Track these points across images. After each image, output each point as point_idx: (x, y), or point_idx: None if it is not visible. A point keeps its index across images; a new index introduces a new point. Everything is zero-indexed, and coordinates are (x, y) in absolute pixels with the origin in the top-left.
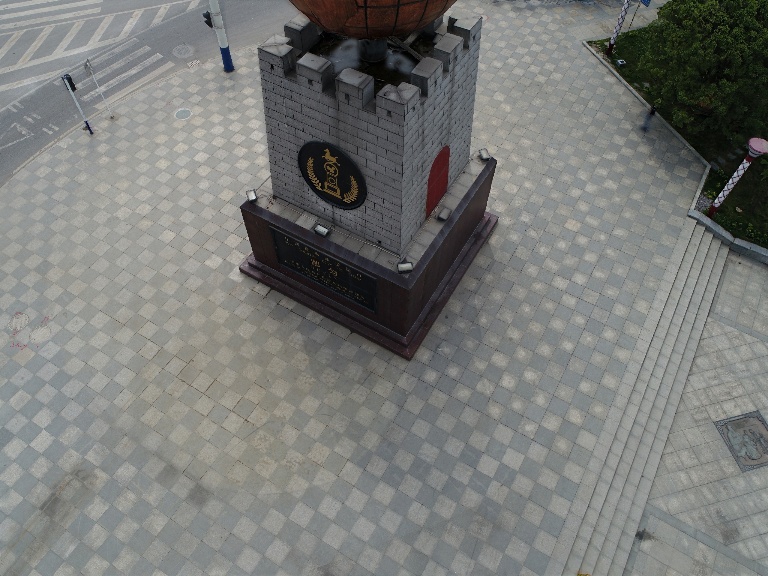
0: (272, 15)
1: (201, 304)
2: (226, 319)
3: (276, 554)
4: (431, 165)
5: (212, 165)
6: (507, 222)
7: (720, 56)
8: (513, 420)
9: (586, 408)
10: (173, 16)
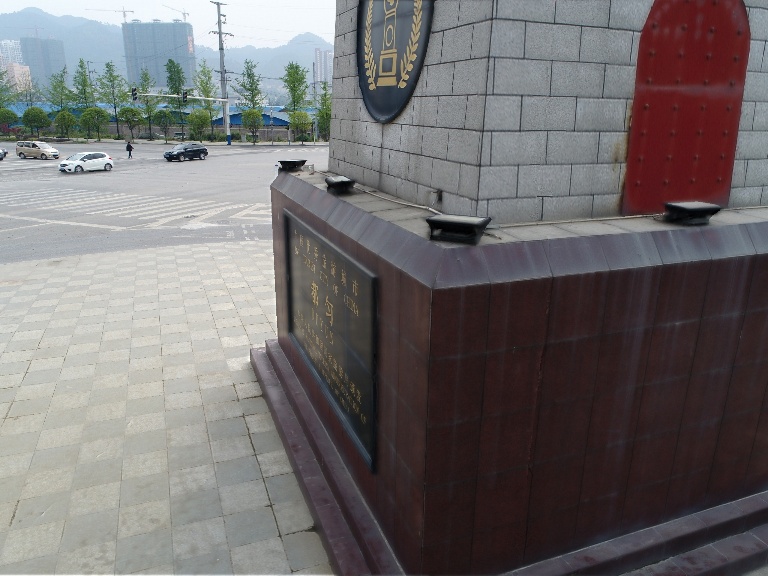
0: None
1: (147, 368)
2: (145, 397)
3: None
4: None
5: None
6: None
7: None
8: None
9: None
10: None
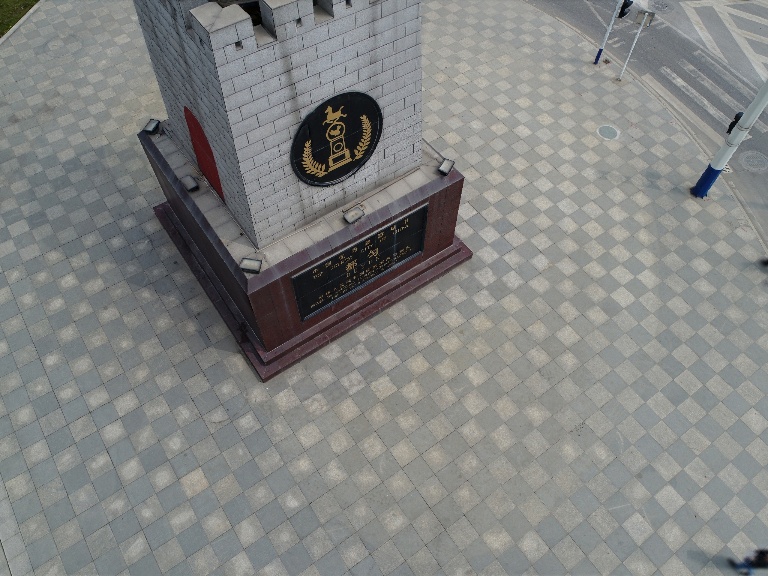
0: None
1: None
2: None
3: (85, 90)
4: None
5: (505, 136)
6: (255, 394)
7: None
8: (33, 266)
9: None
10: None
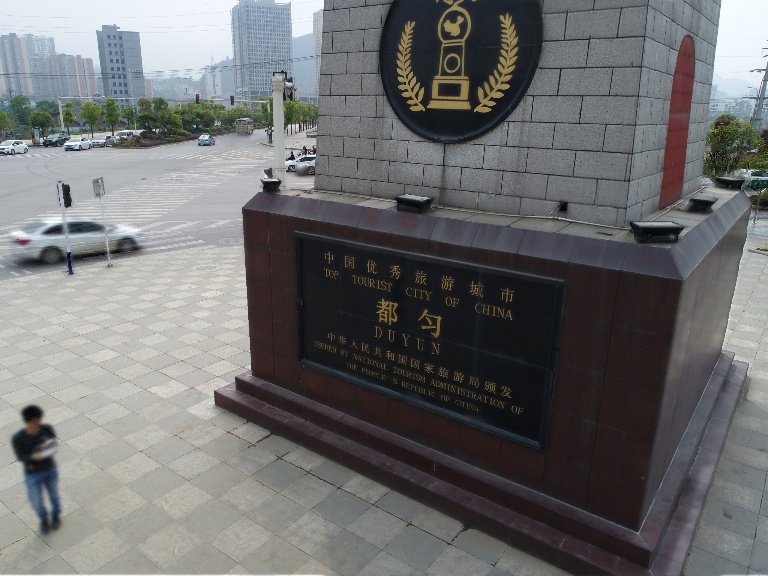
0: None
1: (101, 445)
2: (143, 474)
3: None
4: (679, 40)
5: (224, 300)
6: (767, 377)
7: None
8: None
9: None
10: (232, 225)
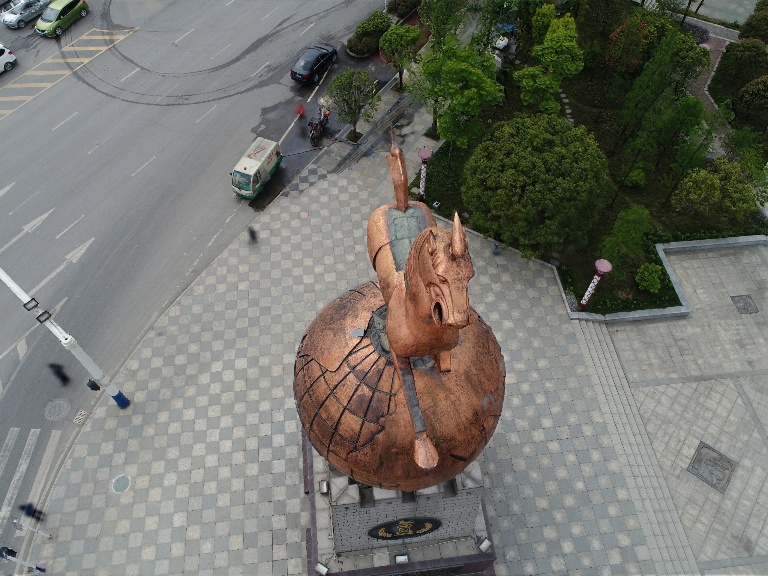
0: (114, 315)
1: None
2: None
3: None
4: None
5: (197, 521)
6: None
7: (536, 207)
8: (593, 575)
9: (625, 528)
10: (11, 375)
